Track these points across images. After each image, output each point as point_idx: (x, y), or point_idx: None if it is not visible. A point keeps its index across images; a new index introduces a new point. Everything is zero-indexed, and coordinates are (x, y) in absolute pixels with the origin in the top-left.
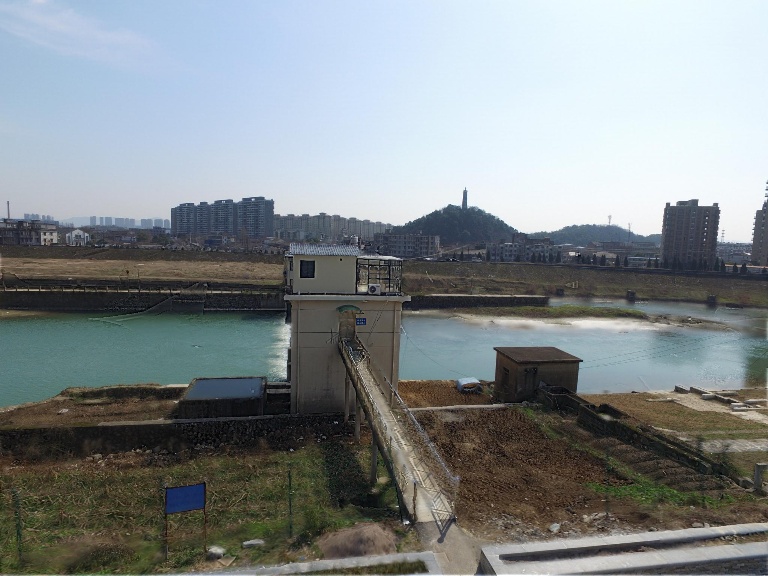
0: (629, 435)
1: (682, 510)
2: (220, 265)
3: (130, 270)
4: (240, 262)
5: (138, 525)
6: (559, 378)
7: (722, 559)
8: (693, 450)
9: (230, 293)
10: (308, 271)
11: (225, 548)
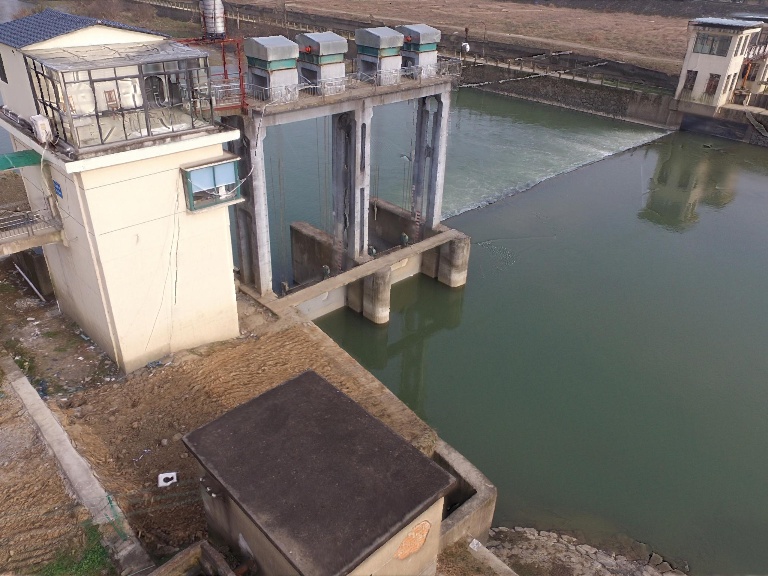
0: None
1: None
2: None
3: (473, 27)
4: None
5: None
6: (278, 571)
7: None
8: None
9: (585, 81)
10: None
11: None
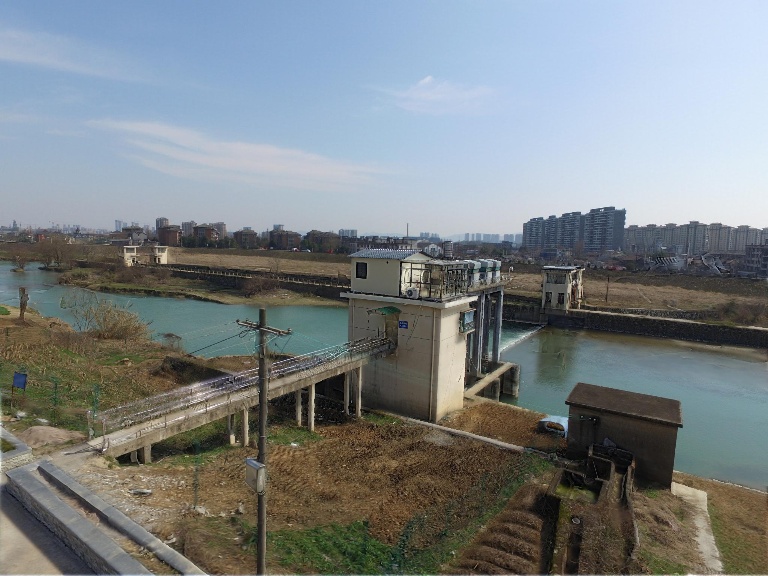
0: (555, 522)
1: (208, 529)
2: (514, 276)
3: None
4: (538, 274)
5: (110, 415)
6: (639, 442)
7: (92, 549)
8: (580, 569)
9: None
10: (362, 272)
11: (29, 416)
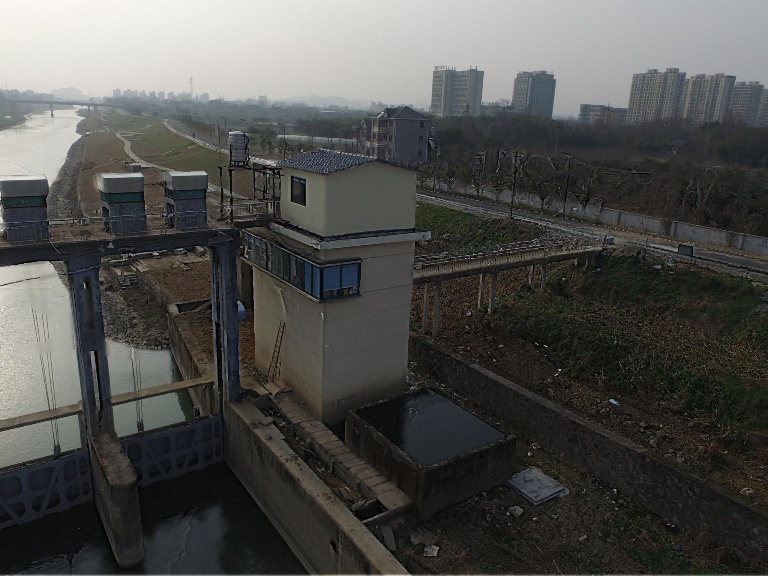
0: None
1: None
2: None
3: None
4: None
5: None
6: None
7: None
8: None
9: None
10: None
11: None
